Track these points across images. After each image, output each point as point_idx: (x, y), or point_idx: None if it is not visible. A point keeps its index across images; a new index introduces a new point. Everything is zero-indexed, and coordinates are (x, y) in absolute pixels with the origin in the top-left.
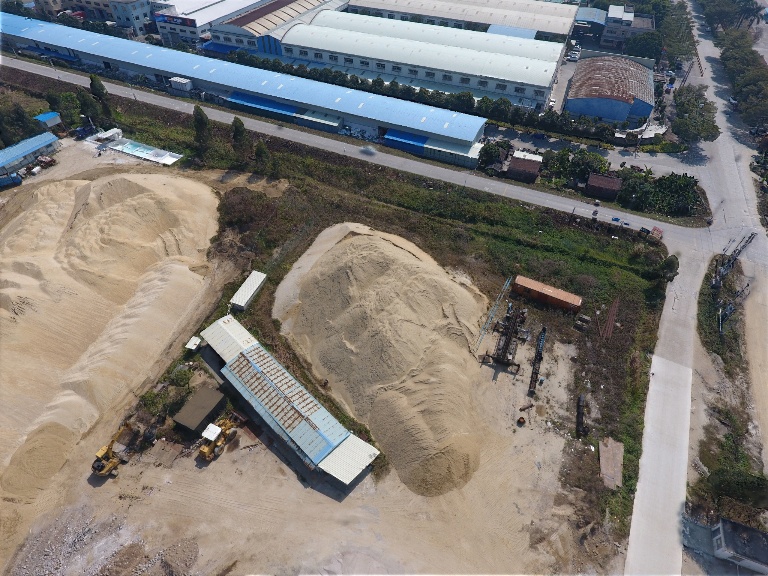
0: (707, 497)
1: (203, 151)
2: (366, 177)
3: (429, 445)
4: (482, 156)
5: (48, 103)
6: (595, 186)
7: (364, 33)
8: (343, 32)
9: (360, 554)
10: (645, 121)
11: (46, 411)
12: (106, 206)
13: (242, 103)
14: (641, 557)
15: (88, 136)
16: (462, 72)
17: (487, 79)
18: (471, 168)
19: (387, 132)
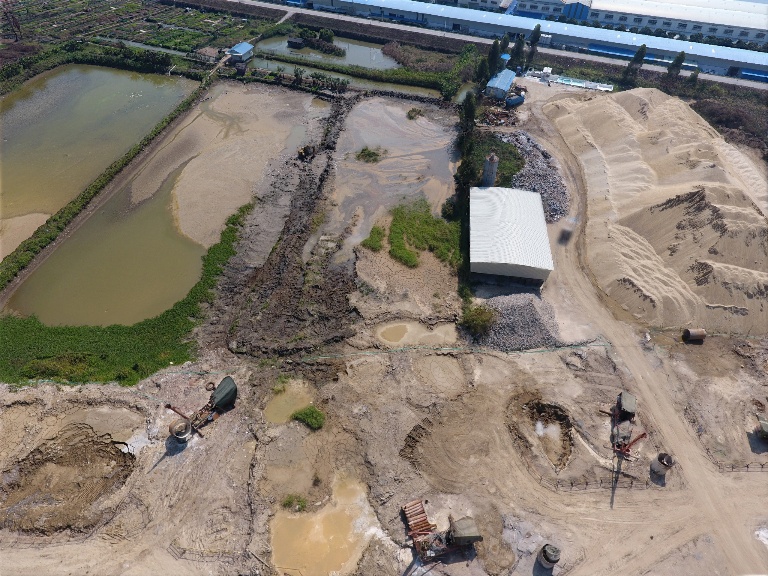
0: None
1: (632, 81)
2: (767, 97)
3: None
4: None
5: (442, 54)
6: None
7: (651, 1)
8: (634, 0)
9: None
10: None
11: (766, 210)
12: (655, 106)
13: (604, 52)
14: None
15: (522, 74)
16: (761, 28)
17: None
18: None
19: (742, 70)
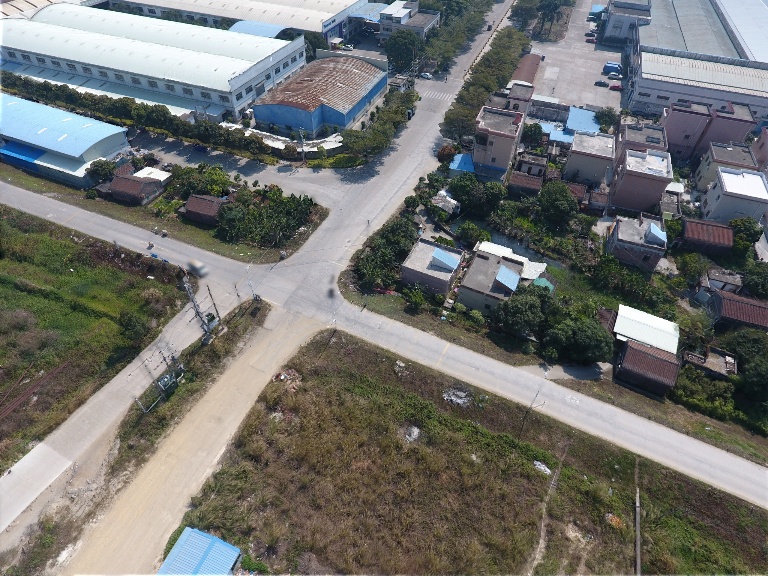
0: None
1: None
2: None
3: None
4: (96, 174)
5: None
6: (192, 211)
7: (75, 29)
8: (51, 28)
9: None
10: (336, 131)
11: None
12: None
13: None
14: None
15: None
16: (145, 74)
17: (171, 82)
18: (79, 188)
19: (5, 145)
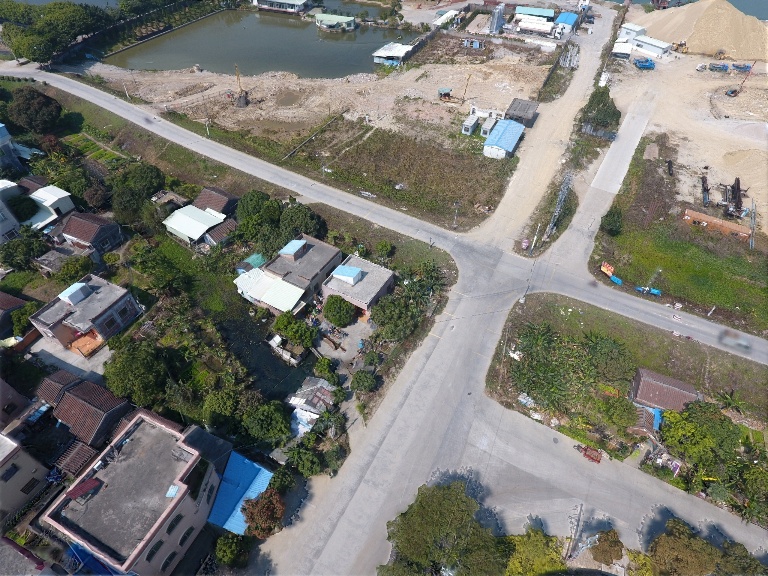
0: (602, 142)
1: None
2: None
3: (761, 150)
4: None
5: None
6: None
7: None
8: None
9: (764, 139)
10: None
11: None
12: None
13: None
14: (637, 133)
15: None
16: None
17: None
18: None
19: None
